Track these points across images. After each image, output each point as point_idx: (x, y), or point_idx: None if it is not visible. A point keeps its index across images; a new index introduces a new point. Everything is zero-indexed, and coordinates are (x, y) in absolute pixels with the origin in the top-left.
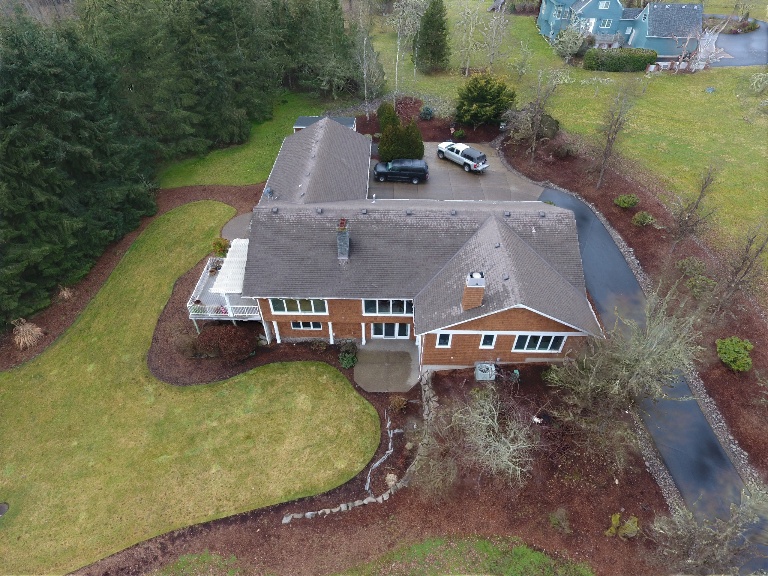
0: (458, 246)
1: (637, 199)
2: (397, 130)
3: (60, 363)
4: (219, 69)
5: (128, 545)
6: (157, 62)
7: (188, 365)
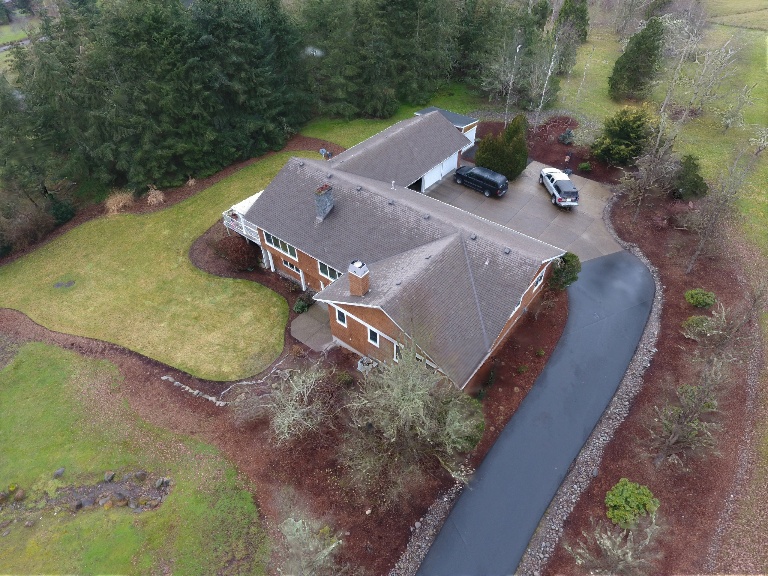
0: (409, 247)
1: (712, 300)
2: (495, 139)
3: (156, 222)
4: (380, 50)
5: (93, 337)
6: (332, 35)
7: (210, 257)
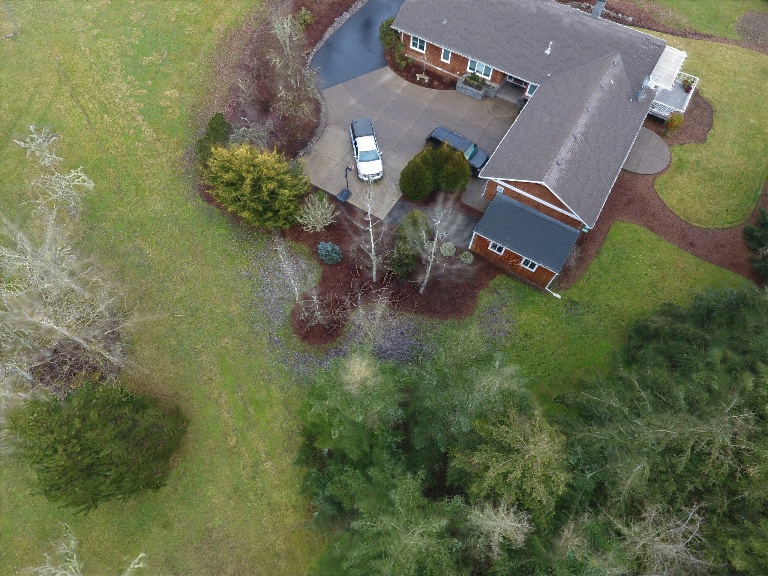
0: None
1: None
2: None
3: None
4: None
5: None
6: None
7: None
